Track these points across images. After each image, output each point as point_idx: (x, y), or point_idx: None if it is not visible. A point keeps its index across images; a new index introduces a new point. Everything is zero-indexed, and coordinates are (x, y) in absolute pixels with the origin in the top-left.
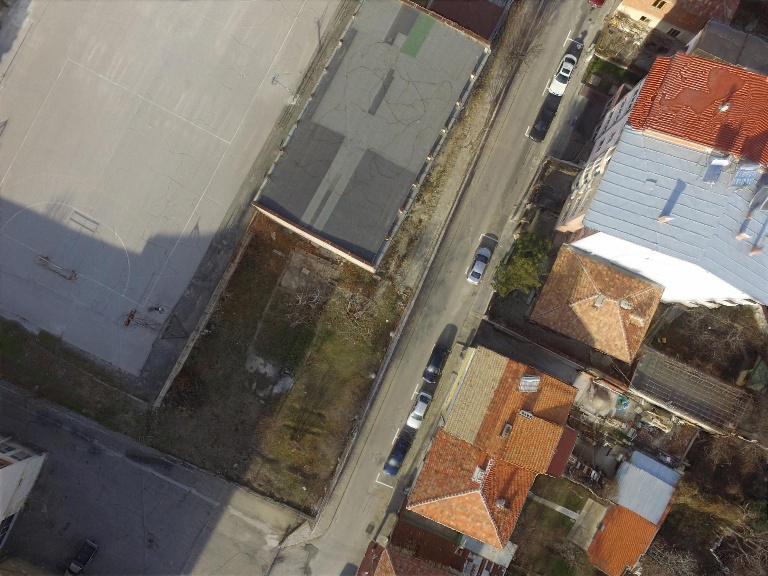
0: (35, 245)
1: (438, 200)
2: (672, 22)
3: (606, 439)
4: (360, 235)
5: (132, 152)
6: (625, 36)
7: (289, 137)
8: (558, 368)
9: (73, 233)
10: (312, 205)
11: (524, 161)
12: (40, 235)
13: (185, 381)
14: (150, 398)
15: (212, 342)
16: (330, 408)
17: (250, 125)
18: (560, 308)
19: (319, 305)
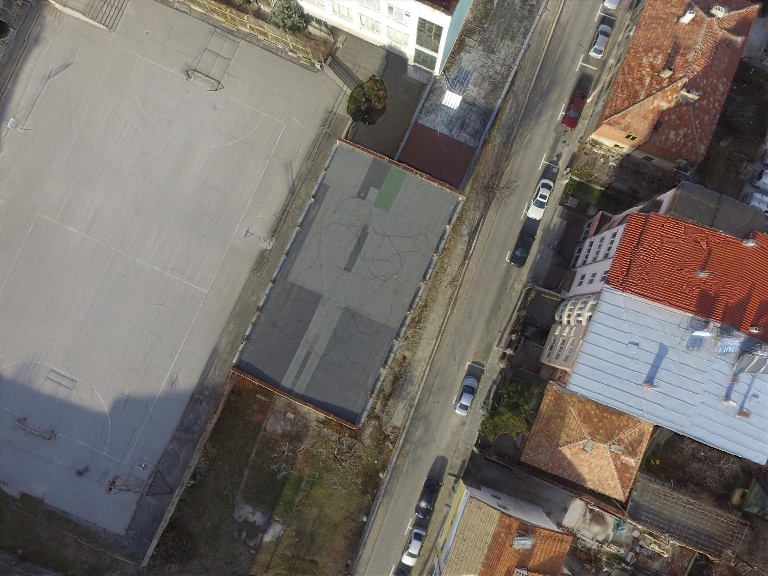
0: (12, 406)
1: (421, 336)
2: (646, 151)
3: (605, 564)
4: (342, 396)
5: (107, 306)
6: (600, 157)
7: (265, 296)
8: (552, 494)
9: (51, 392)
10: (292, 368)
11: (506, 286)
12: (17, 396)
13: (172, 537)
14: (137, 557)
15: (198, 493)
16: (322, 554)
17: (226, 272)
18: (550, 451)
19: (306, 449)
